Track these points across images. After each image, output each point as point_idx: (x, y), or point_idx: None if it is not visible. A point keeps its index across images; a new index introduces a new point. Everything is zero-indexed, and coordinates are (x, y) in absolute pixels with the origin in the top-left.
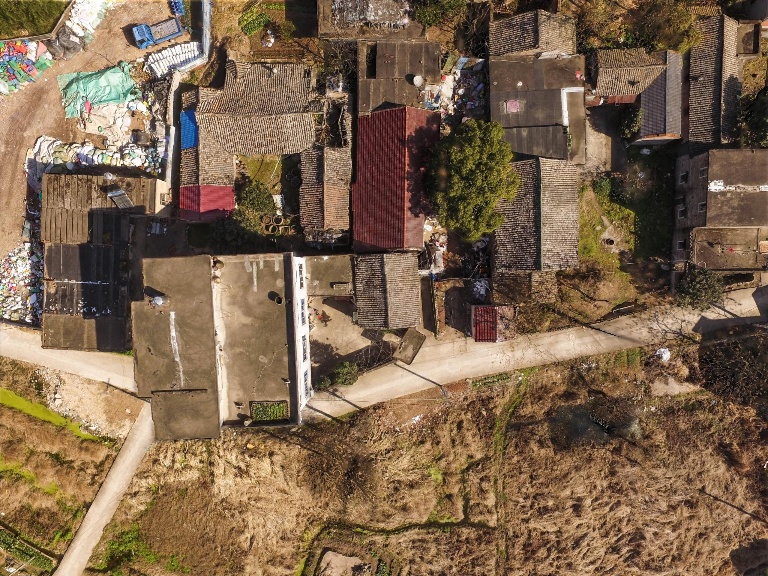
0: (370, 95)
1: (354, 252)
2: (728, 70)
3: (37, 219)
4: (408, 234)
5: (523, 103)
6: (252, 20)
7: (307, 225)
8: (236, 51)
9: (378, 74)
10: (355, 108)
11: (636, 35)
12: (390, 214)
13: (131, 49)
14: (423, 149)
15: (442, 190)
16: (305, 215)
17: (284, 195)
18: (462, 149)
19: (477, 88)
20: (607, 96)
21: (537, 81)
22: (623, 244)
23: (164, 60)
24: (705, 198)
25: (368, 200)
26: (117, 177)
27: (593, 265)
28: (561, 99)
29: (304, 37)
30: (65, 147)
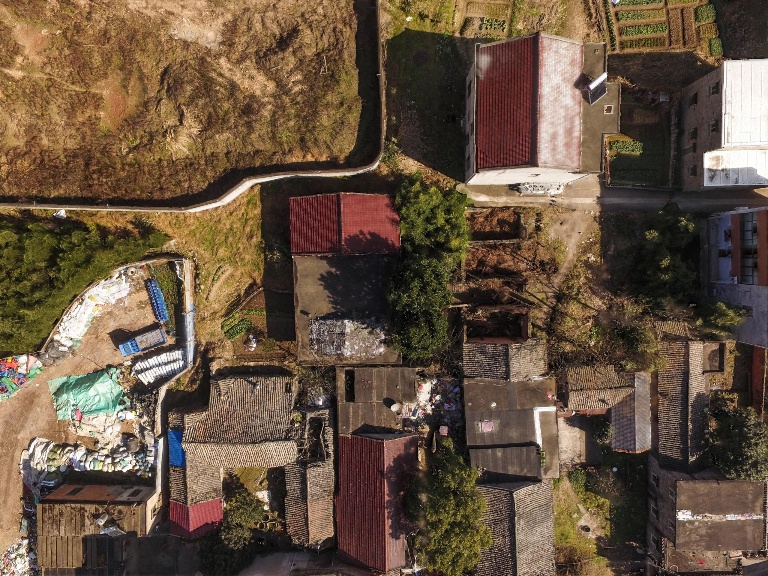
0: (349, 418)
1: (339, 559)
2: (695, 390)
3: (34, 516)
4: (389, 558)
5: (497, 423)
6: (234, 326)
7: (293, 535)
8: (220, 359)
9: (357, 398)
10: (336, 420)
11: (606, 338)
12: (372, 536)
13: (118, 353)
14: (402, 474)
15: (421, 519)
16: (291, 524)
17: (271, 491)
18: (437, 513)
19: (454, 390)
20: (579, 410)
21: (510, 401)
22: (599, 530)
23: (150, 371)
24: (674, 524)
25: (351, 516)
26: (108, 508)
27: (570, 554)
28: (534, 418)
29: (285, 341)
30: (58, 452)
